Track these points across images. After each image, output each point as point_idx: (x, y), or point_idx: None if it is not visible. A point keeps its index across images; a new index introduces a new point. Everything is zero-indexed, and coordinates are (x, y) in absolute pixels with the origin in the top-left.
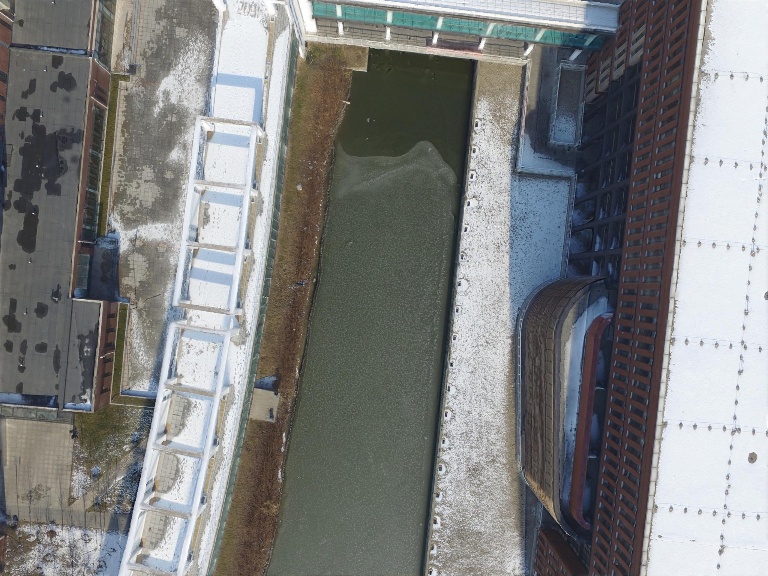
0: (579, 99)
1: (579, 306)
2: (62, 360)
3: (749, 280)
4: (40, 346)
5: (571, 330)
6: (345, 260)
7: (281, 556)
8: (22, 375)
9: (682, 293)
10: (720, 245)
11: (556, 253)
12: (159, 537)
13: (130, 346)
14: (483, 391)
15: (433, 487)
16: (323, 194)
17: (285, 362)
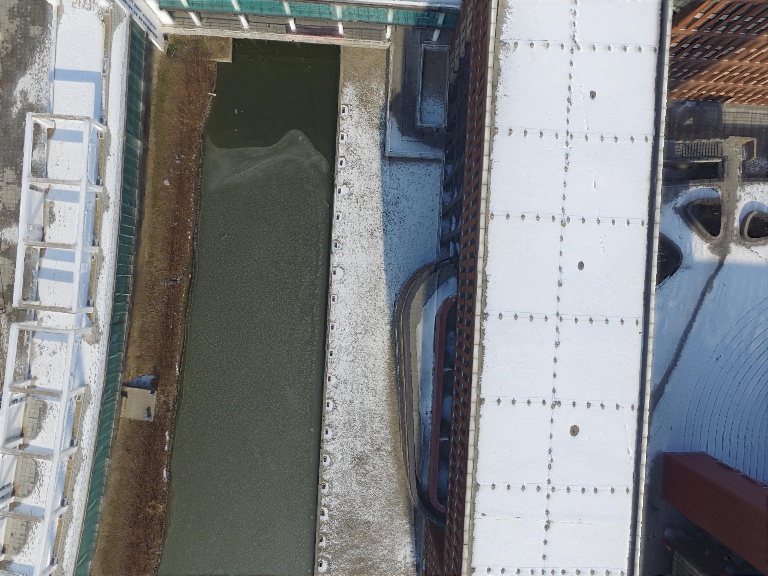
0: (445, 80)
1: (428, 287)
2: None
3: (561, 251)
4: None
5: (421, 312)
6: (220, 254)
7: (171, 556)
8: None
9: (493, 267)
10: (529, 217)
11: (431, 237)
12: (22, 542)
13: (1, 351)
14: (364, 379)
15: (319, 479)
16: (194, 188)
17: (163, 360)
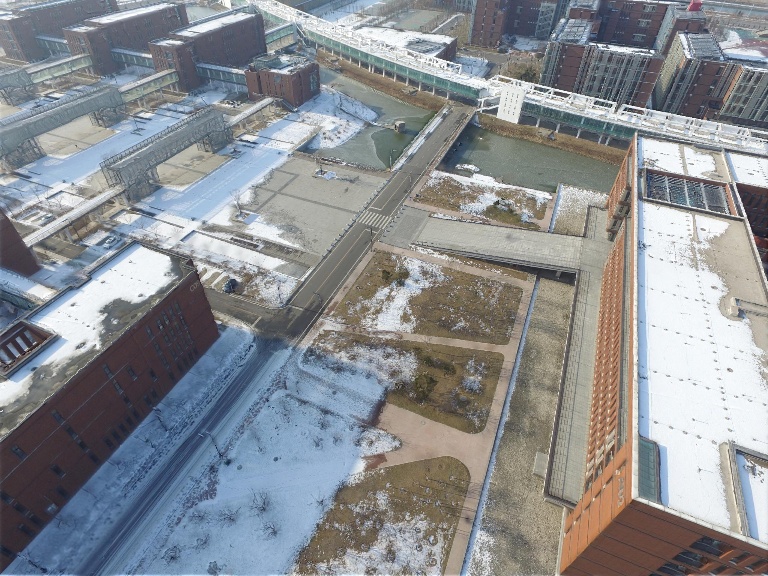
0: None
1: None
2: None
3: None
4: None
5: None
6: None
7: None
8: None
9: None
10: None
11: None
12: None
13: None
14: None
15: None
16: None
17: None
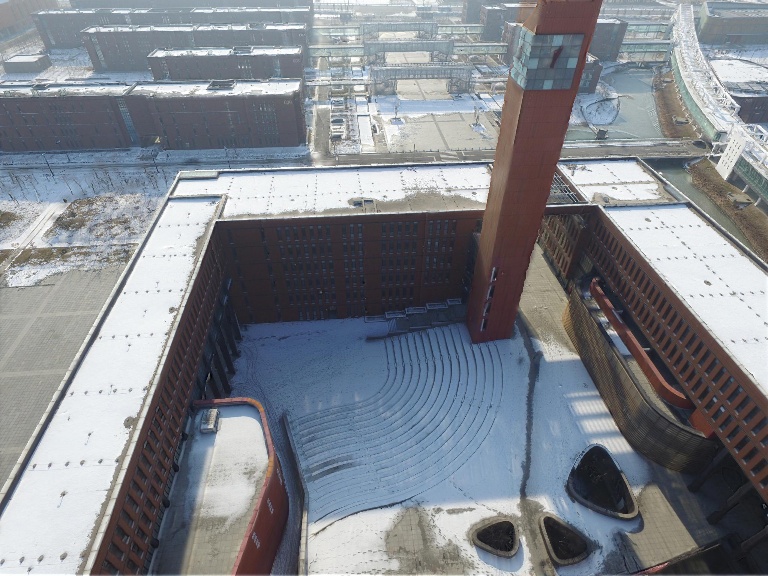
0: None
1: None
2: None
3: None
4: None
5: None
6: None
7: None
8: None
9: None
10: None
11: None
12: None
13: None
14: None
15: None
16: None
17: None
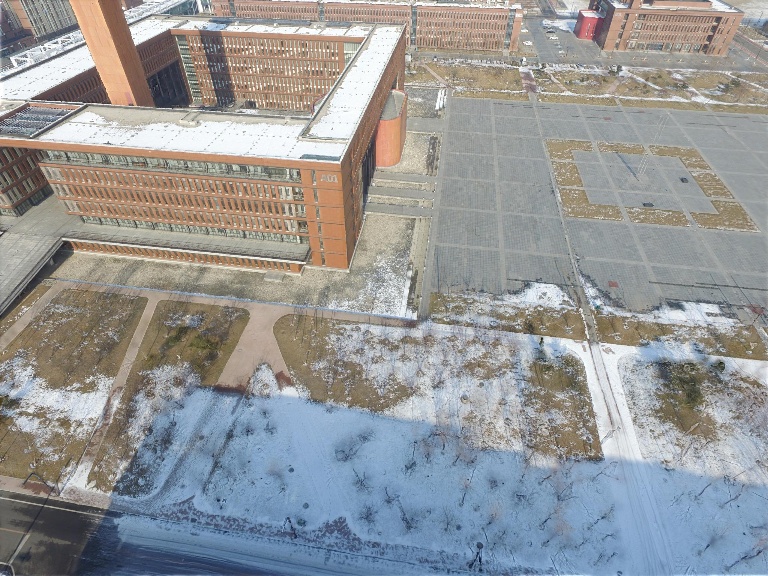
0: None
1: None
2: None
3: None
4: None
5: None
6: None
7: None
8: None
9: None
10: None
11: None
12: None
13: None
14: None
15: None
16: None
17: None
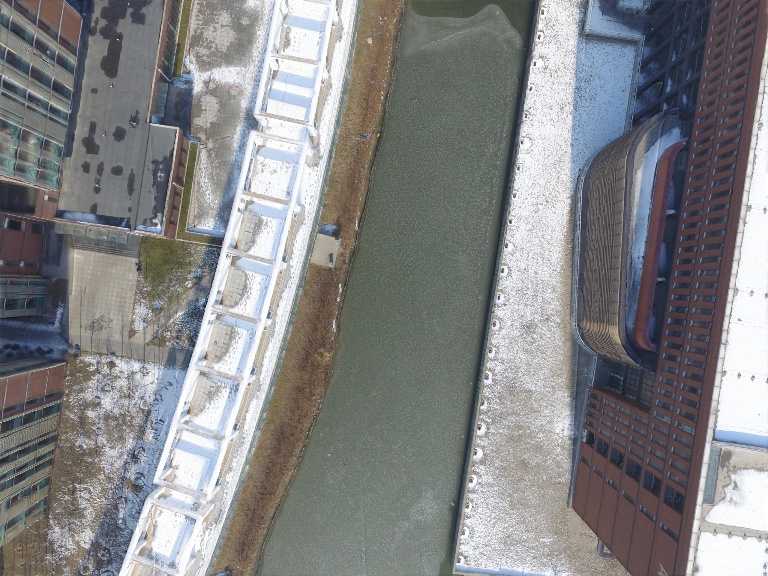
0: None
1: (652, 135)
2: (136, 183)
3: None
4: (116, 169)
5: (643, 158)
6: (409, 117)
7: (331, 406)
8: (97, 196)
9: None
10: None
11: (619, 116)
12: (224, 351)
13: (198, 185)
14: (540, 250)
15: (486, 343)
16: (391, 51)
17: (346, 212)
